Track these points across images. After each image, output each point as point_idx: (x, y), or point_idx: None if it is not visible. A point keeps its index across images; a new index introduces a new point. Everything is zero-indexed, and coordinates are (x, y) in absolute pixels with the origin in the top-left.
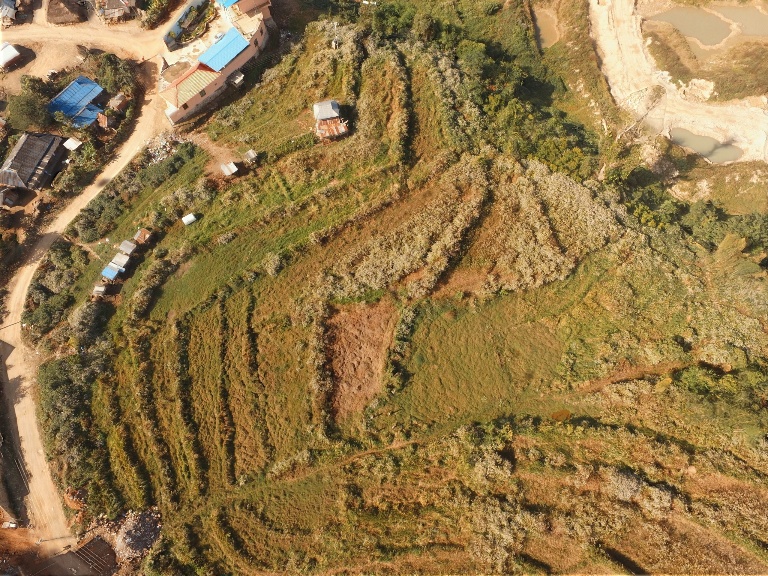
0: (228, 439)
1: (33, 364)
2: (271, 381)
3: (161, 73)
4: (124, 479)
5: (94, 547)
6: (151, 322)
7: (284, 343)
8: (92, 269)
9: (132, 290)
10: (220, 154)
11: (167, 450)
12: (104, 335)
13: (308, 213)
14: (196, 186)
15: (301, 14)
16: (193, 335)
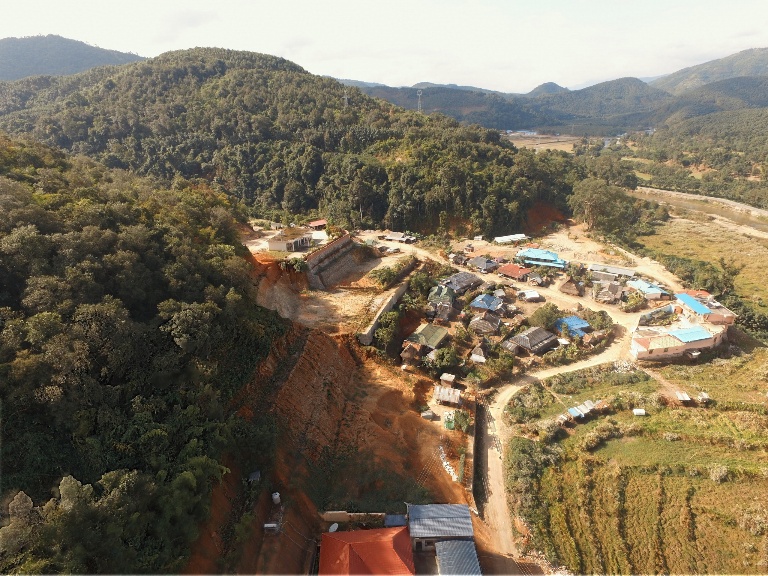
0: (663, 574)
1: (506, 434)
2: (711, 557)
3: (636, 330)
4: (561, 541)
5: (533, 569)
6: (597, 456)
7: (727, 536)
8: (557, 407)
9: (585, 431)
10: (671, 387)
11: (600, 546)
12: (560, 445)
13: (757, 455)
14: (650, 396)
15: (751, 340)
16: (631, 483)
